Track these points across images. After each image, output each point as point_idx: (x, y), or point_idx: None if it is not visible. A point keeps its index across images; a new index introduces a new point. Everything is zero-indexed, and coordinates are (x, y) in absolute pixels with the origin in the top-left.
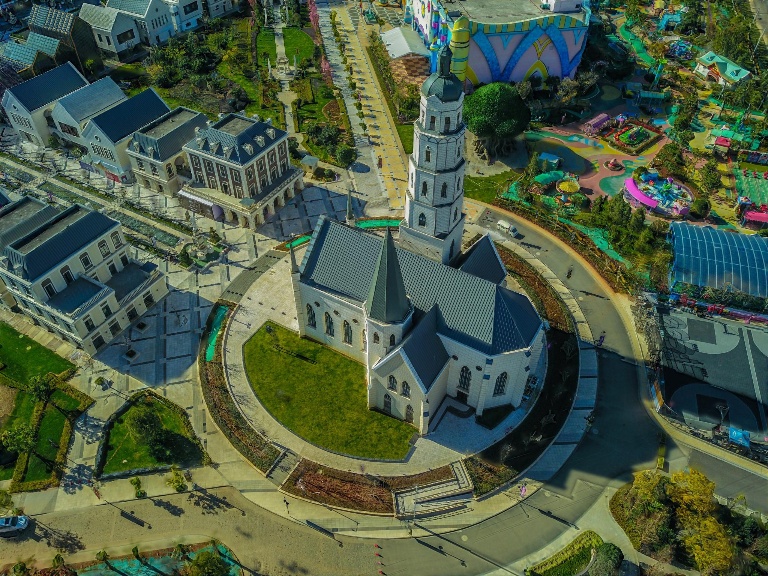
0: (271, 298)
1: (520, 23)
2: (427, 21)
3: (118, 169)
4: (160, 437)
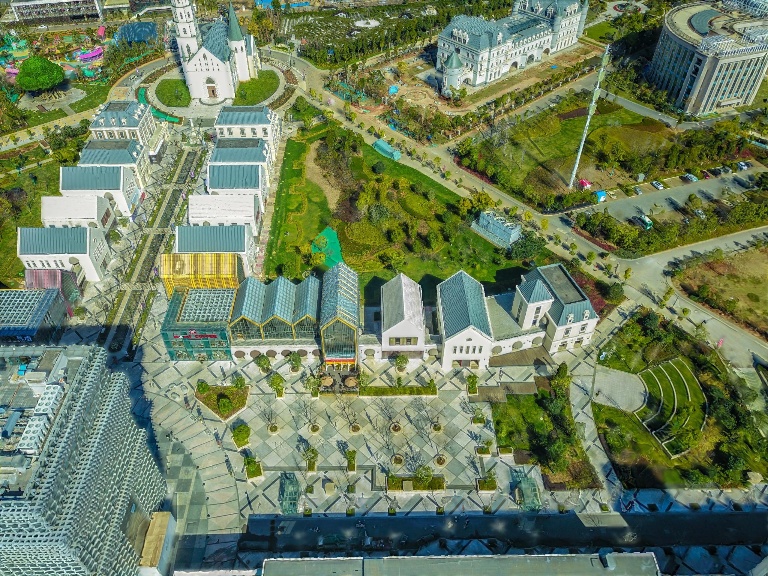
0: None
1: None
2: None
3: None
4: None
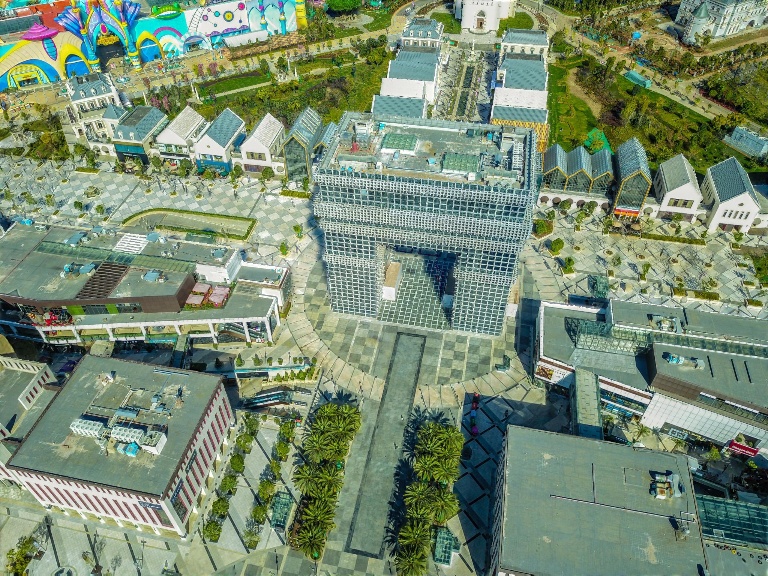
0: (485, 39)
1: None
2: None
3: None
4: (555, 44)
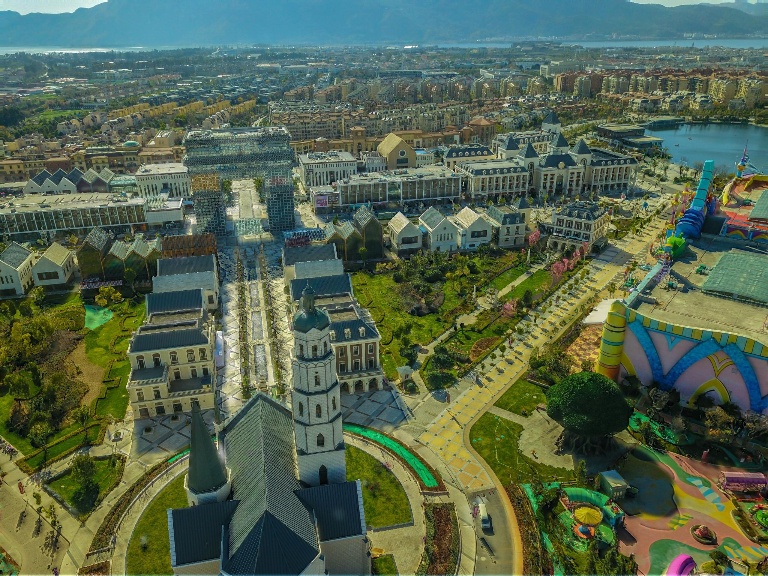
0: None
1: (690, 329)
2: None
3: None
4: (91, 487)
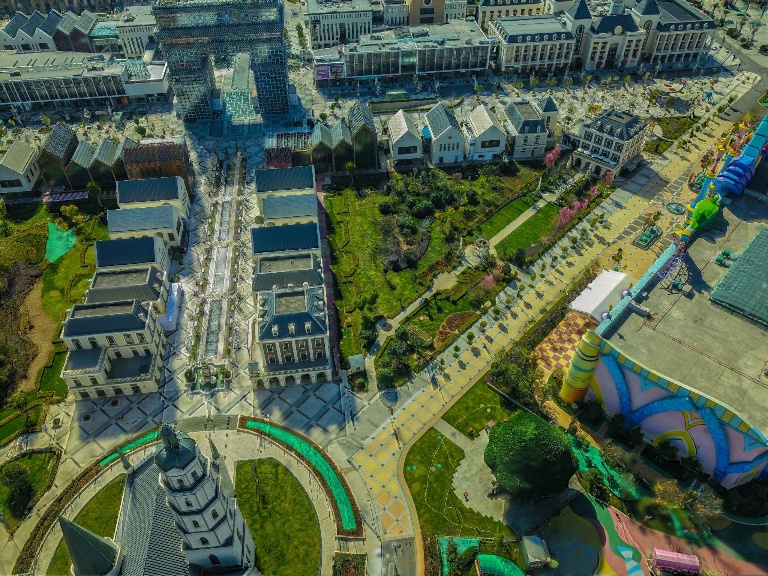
0: None
1: (666, 380)
2: None
3: None
4: (24, 489)
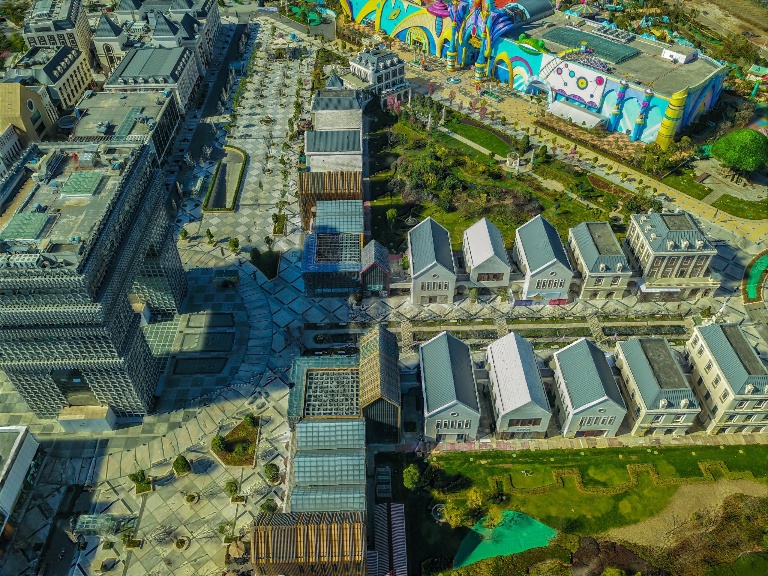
0: None
1: (706, 80)
2: (595, 92)
3: (560, 293)
4: None
